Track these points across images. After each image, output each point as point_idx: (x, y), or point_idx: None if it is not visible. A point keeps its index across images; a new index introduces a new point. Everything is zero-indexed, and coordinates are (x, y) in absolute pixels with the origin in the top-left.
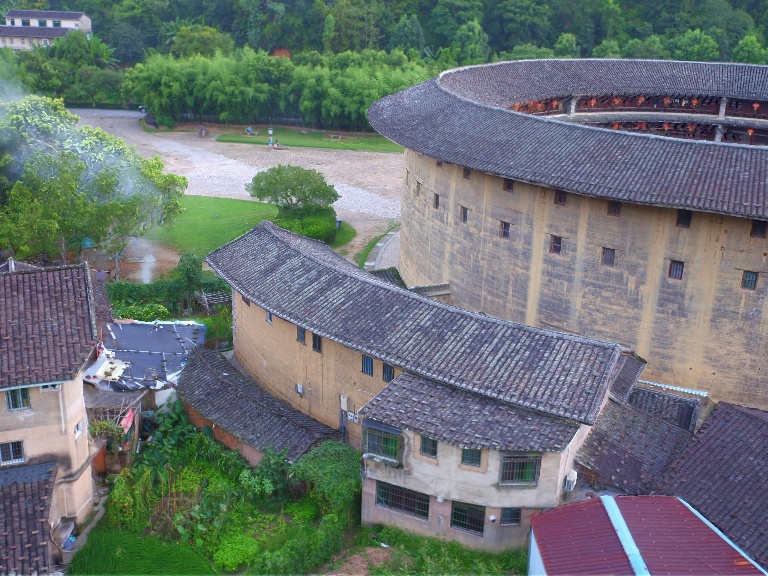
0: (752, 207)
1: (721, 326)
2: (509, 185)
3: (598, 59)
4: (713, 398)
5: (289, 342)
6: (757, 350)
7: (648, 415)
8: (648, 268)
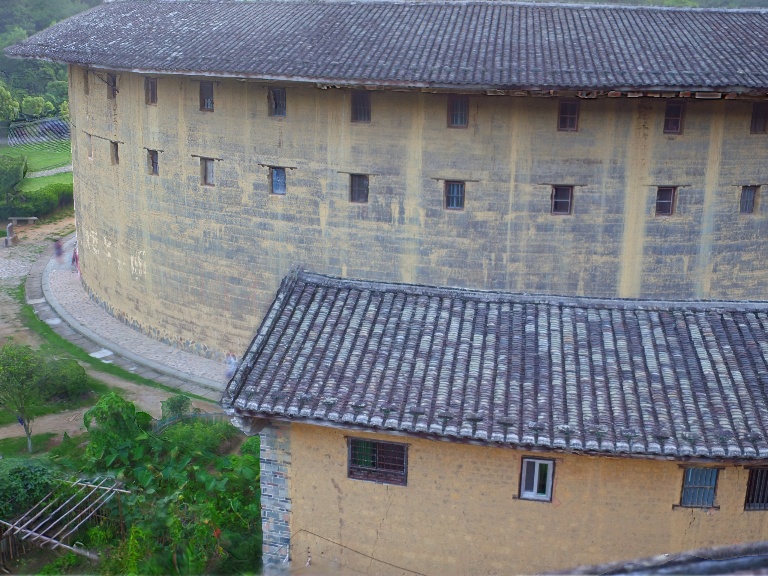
0: None
1: None
2: (563, 121)
3: None
4: None
5: (639, 521)
6: None
7: None
8: None
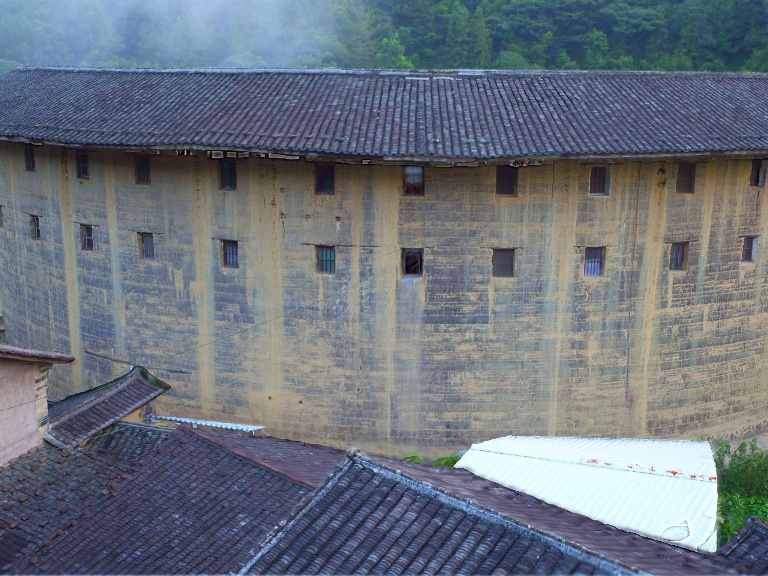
0: (284, 139)
1: (298, 331)
2: (33, 162)
3: None
4: (305, 439)
5: None
6: (351, 362)
7: (106, 463)
8: (195, 255)
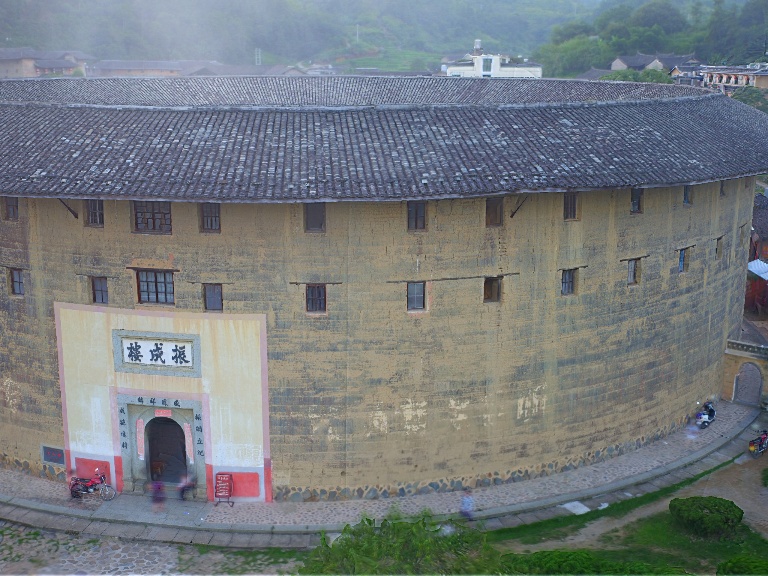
0: None
1: None
2: None
3: None
4: None
5: None
6: None
7: None
8: None
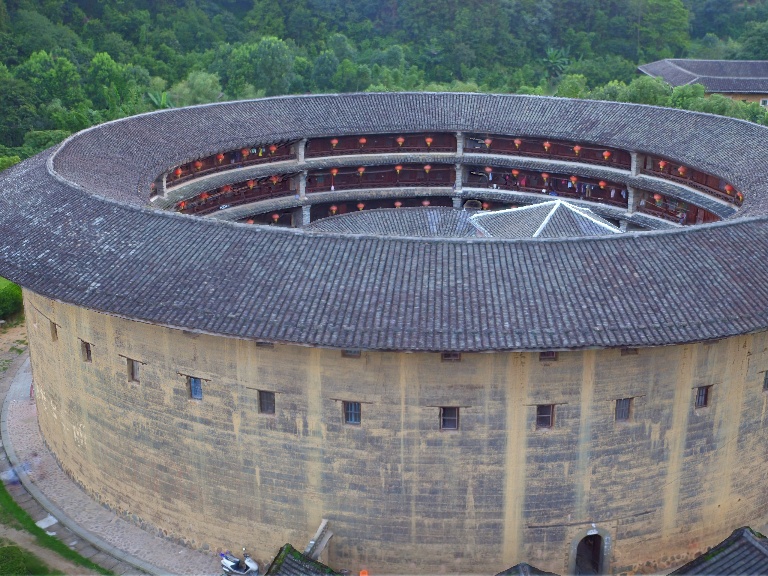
0: None
1: (746, 444)
2: None
3: (147, 114)
4: (738, 527)
5: None
6: None
7: None
8: (674, 407)
